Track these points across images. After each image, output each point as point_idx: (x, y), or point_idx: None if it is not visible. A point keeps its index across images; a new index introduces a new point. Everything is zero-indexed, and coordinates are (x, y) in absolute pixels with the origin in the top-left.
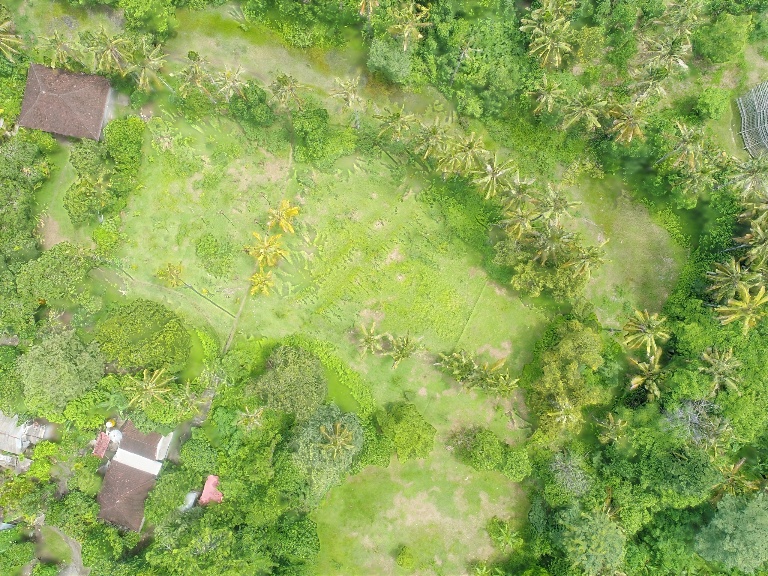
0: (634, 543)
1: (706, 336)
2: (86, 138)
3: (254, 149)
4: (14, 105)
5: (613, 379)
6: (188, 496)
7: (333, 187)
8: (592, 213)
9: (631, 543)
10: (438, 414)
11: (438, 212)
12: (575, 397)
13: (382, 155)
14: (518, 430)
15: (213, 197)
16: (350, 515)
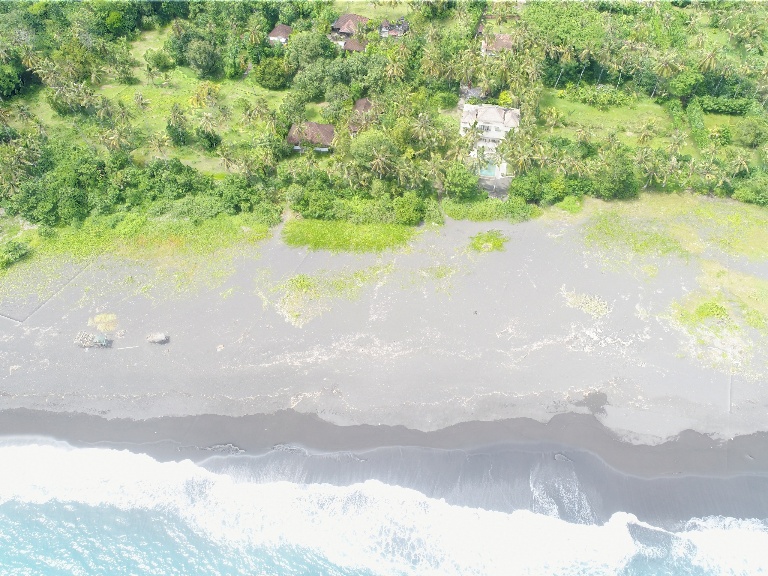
0: None
1: (3, 67)
2: None
3: None
4: None
5: None
6: None
7: None
8: None
9: None
10: None
11: None
12: None
13: None
14: None
15: None
16: None
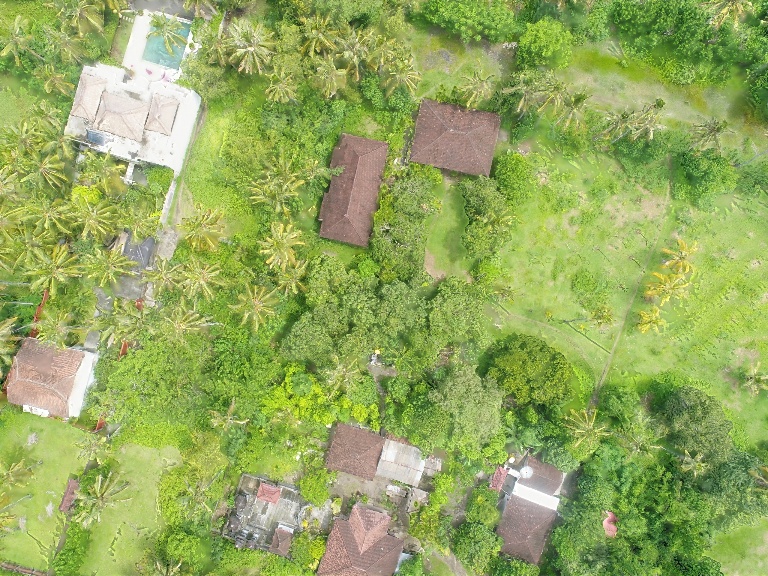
0: None
1: None
2: (477, 174)
3: (632, 186)
4: (400, 140)
5: None
6: None
7: (710, 225)
8: None
9: None
10: None
11: None
12: None
13: (760, 194)
14: None
15: (589, 233)
16: (720, 551)
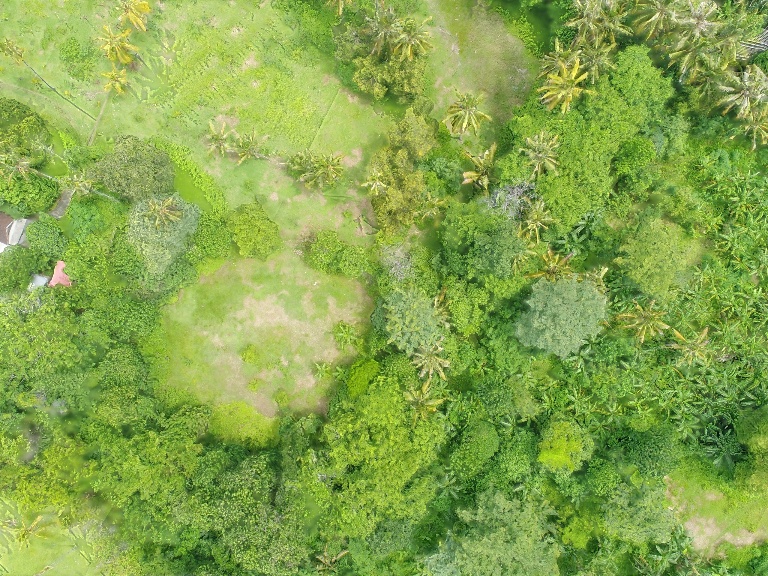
0: (472, 346)
1: (536, 126)
2: None
3: None
4: None
5: (455, 181)
6: (38, 279)
7: None
8: (447, 22)
9: (467, 343)
10: (288, 219)
11: (294, 19)
12: (404, 186)
13: None
14: (366, 236)
15: (77, 2)
16: (201, 314)
